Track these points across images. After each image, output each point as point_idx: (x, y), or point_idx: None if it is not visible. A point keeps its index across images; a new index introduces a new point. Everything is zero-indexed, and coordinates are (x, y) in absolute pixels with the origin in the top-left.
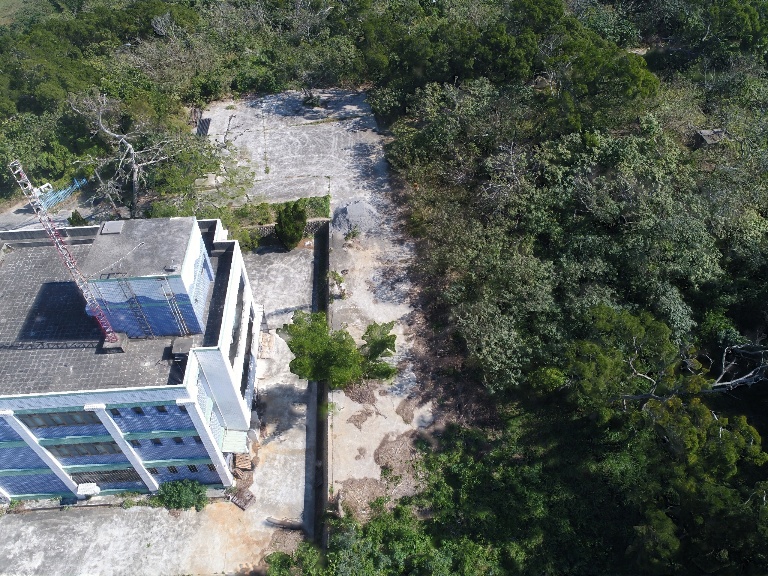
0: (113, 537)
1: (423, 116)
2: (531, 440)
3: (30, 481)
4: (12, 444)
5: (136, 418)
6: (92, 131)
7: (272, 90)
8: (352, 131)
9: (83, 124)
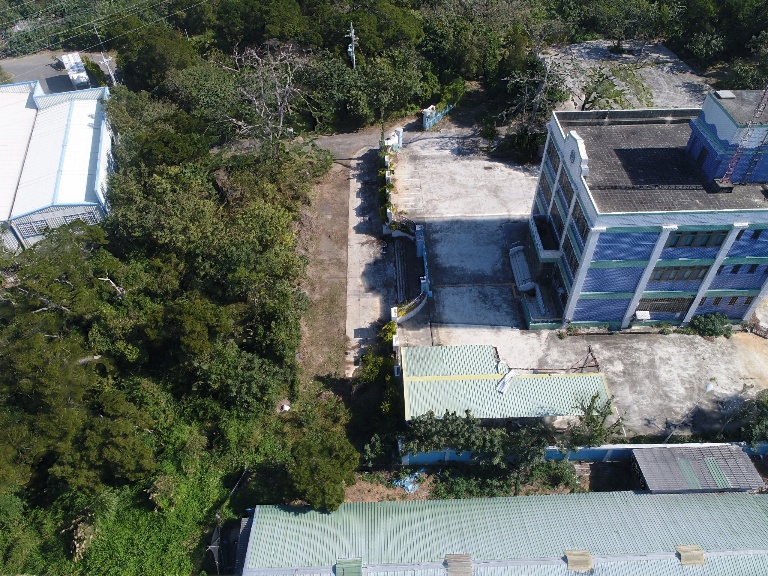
0: (670, 353)
1: (762, 56)
2: None
3: (600, 307)
4: (635, 263)
5: (748, 242)
6: (525, 52)
7: (574, 40)
8: (672, 73)
9: (461, 56)
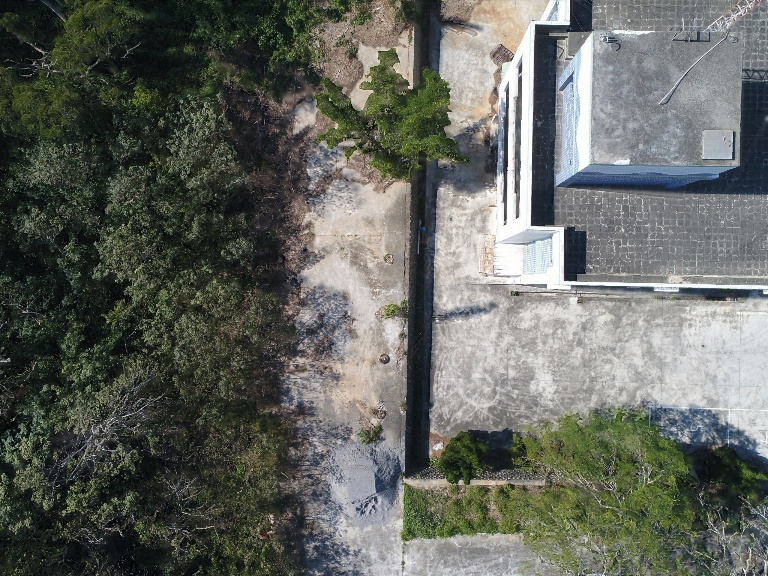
0: None
1: None
2: (194, 63)
3: None
4: None
5: None
6: None
7: None
8: None
9: None
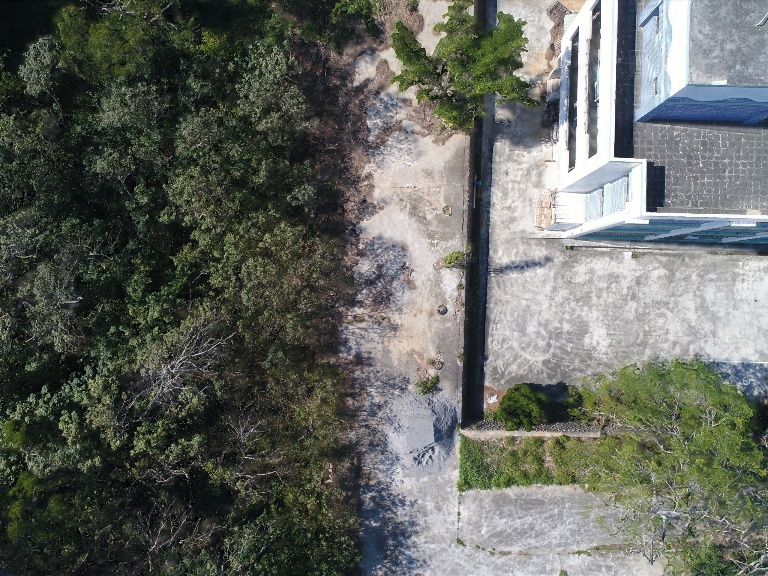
0: None
1: None
2: (257, 14)
3: None
4: None
5: None
6: None
7: None
8: None
9: None
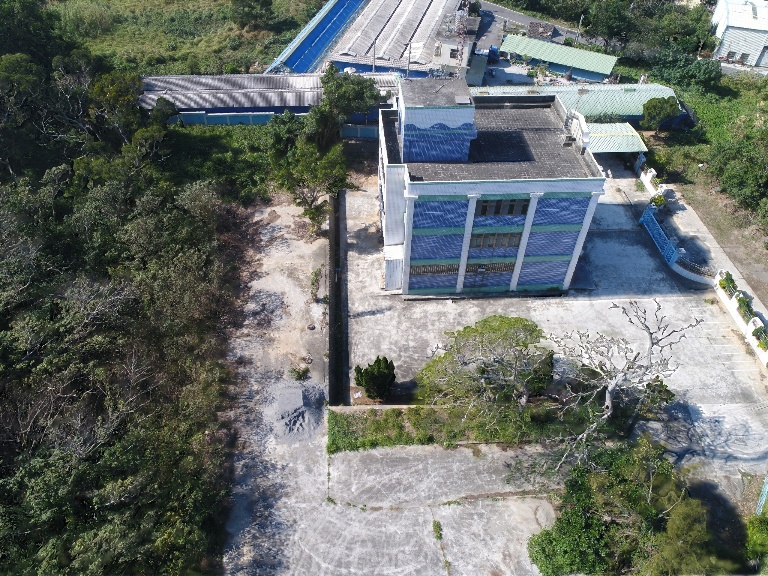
0: None
1: None
2: None
3: None
4: None
5: None
6: None
7: None
8: None
9: None
